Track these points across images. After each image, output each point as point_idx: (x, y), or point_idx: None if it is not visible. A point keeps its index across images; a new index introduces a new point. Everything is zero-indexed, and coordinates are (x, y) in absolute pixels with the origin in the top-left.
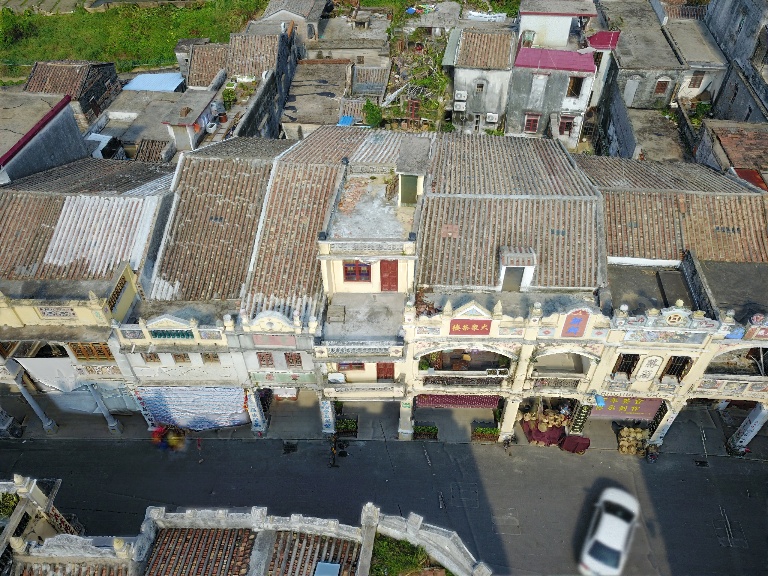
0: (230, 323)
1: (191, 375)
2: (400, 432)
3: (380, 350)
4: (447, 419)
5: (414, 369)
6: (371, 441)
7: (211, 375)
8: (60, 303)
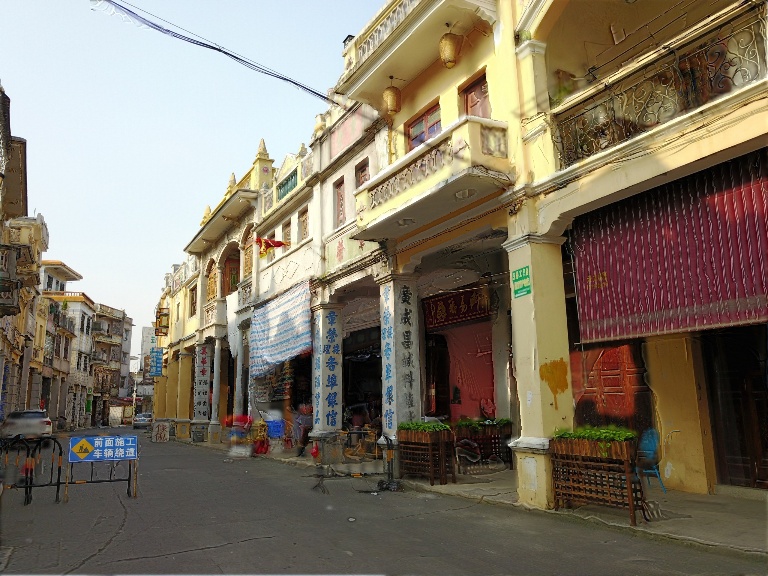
0: (319, 122)
1: (288, 278)
2: (513, 443)
3: None
4: (758, 520)
5: (528, 98)
6: (452, 497)
7: (300, 272)
8: None
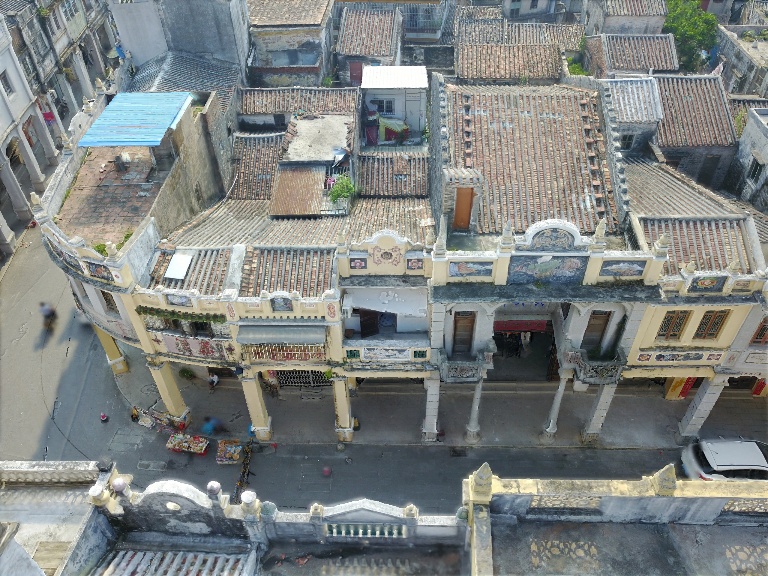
0: None
1: None
2: None
3: (14, 476)
4: None
5: None
6: None
7: None
8: (554, 485)
